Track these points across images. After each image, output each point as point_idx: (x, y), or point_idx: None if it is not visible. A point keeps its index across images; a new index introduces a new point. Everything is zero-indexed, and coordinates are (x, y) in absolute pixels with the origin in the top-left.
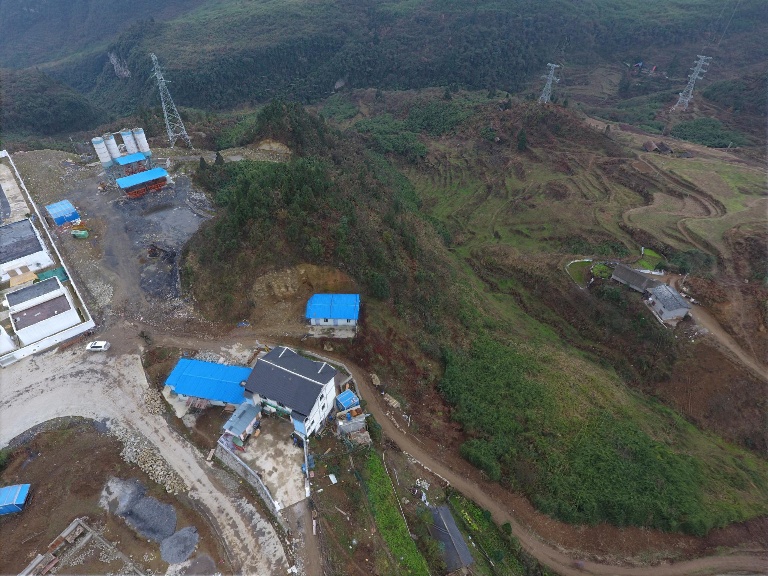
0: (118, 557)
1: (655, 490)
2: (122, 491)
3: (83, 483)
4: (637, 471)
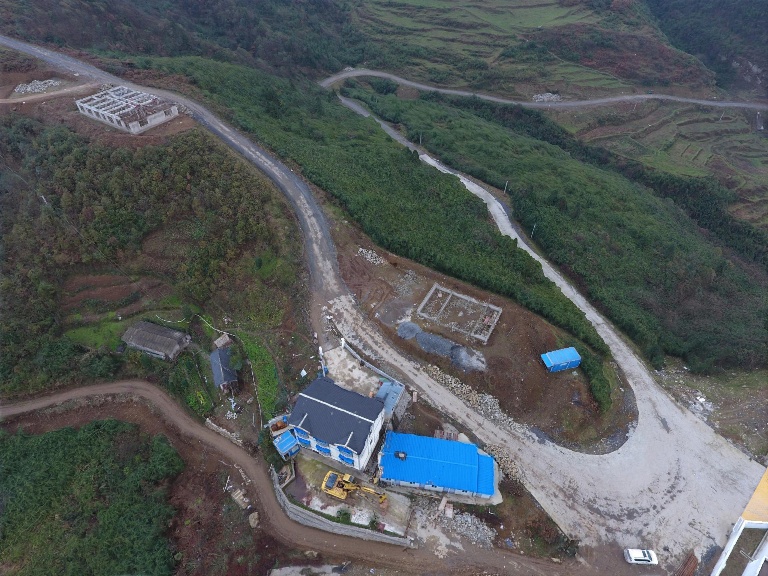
0: (447, 325)
1: (7, 458)
2: (470, 361)
3: (501, 358)
4: (4, 483)
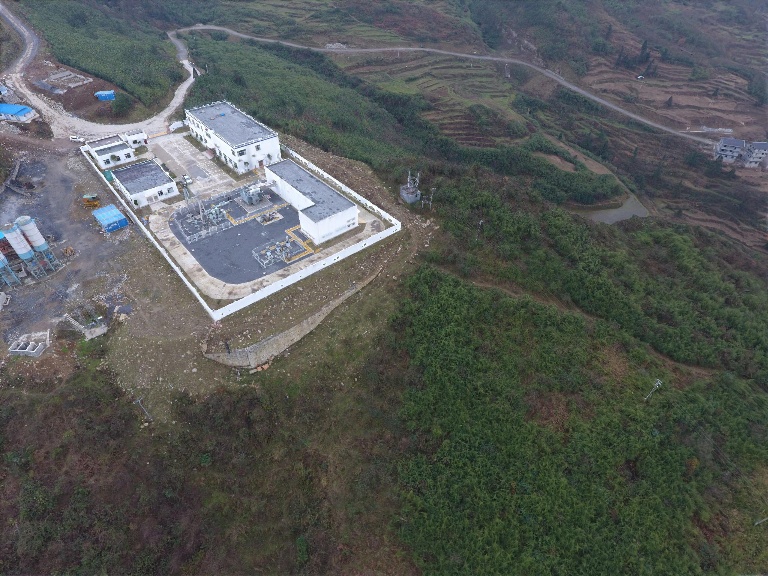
0: None
1: None
2: None
3: None
4: None
